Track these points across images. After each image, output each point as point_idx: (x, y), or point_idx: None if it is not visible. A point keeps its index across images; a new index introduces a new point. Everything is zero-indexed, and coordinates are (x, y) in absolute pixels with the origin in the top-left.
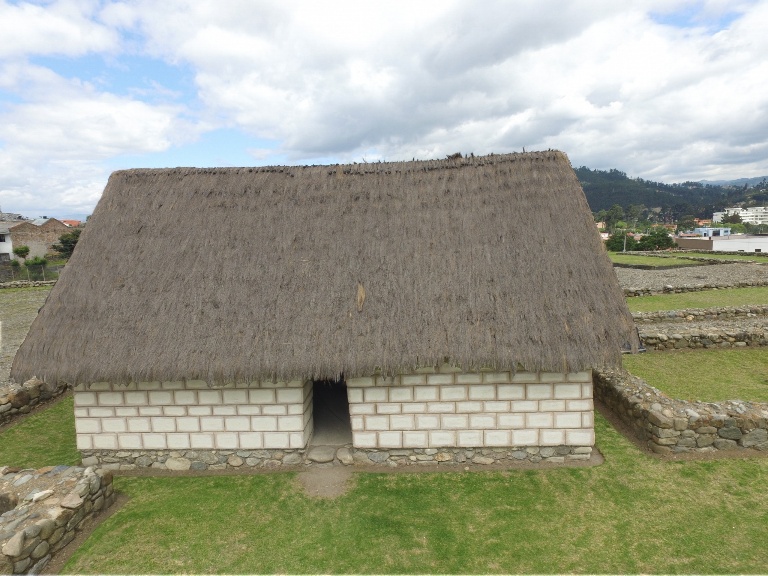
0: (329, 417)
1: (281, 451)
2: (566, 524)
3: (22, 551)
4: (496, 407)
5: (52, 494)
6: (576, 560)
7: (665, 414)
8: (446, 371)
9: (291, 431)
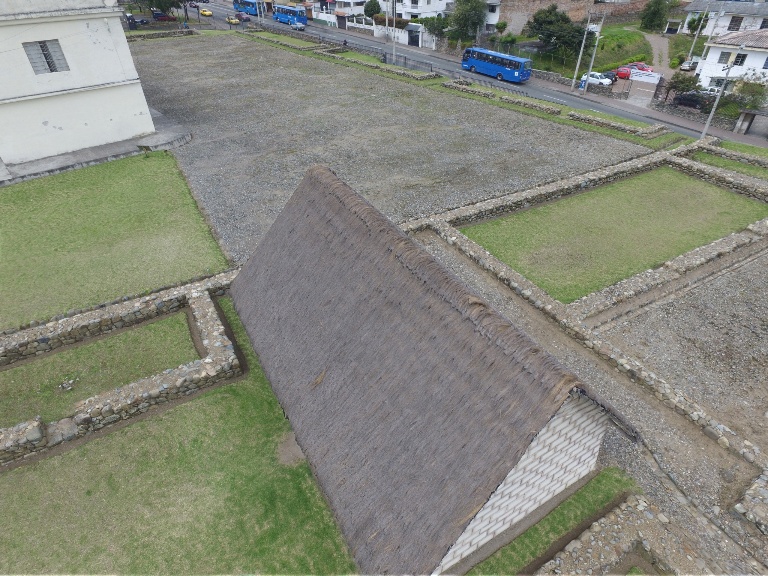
0: None
1: None
2: None
3: None
4: None
5: (211, 363)
6: None
7: None
8: None
9: None
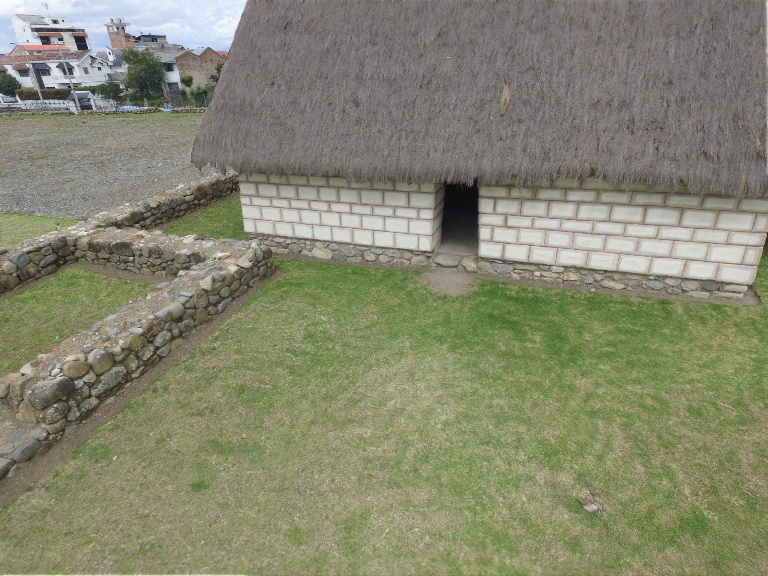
0: (457, 232)
1: (410, 252)
2: (694, 349)
3: (213, 289)
4: (640, 231)
5: (229, 256)
6: (697, 378)
7: None
8: (589, 187)
9: (421, 234)
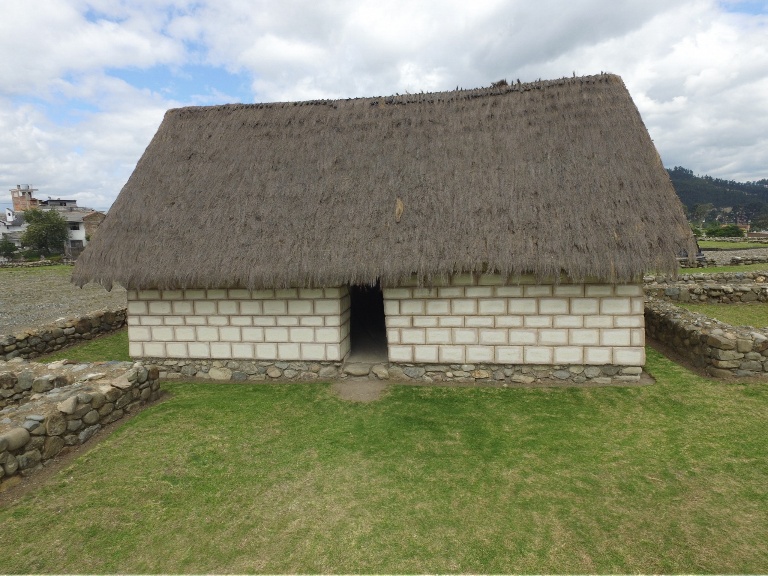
0: (367, 345)
1: (318, 364)
2: (610, 429)
3: (75, 412)
4: (537, 322)
5: (104, 377)
6: (620, 455)
7: (726, 337)
8: (485, 283)
9: (328, 343)
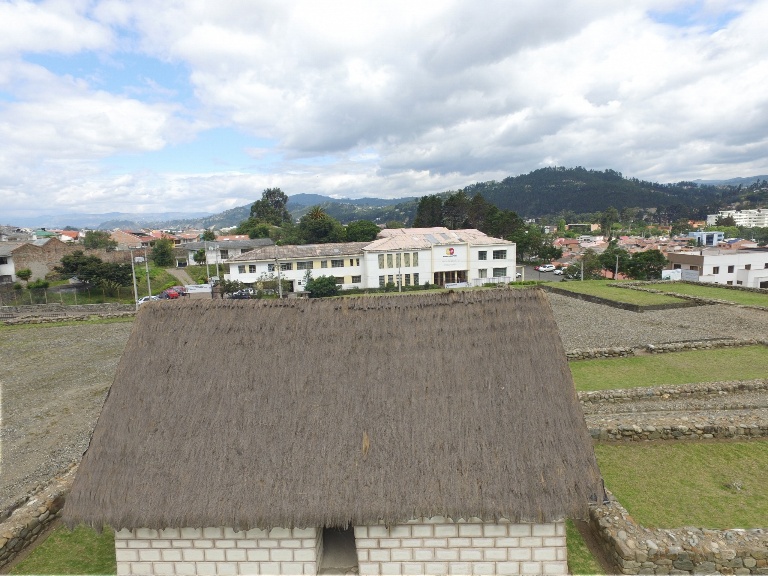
0: None
1: None
2: None
3: None
4: (483, 543)
5: None
6: None
7: (629, 546)
8: (439, 513)
9: (305, 562)
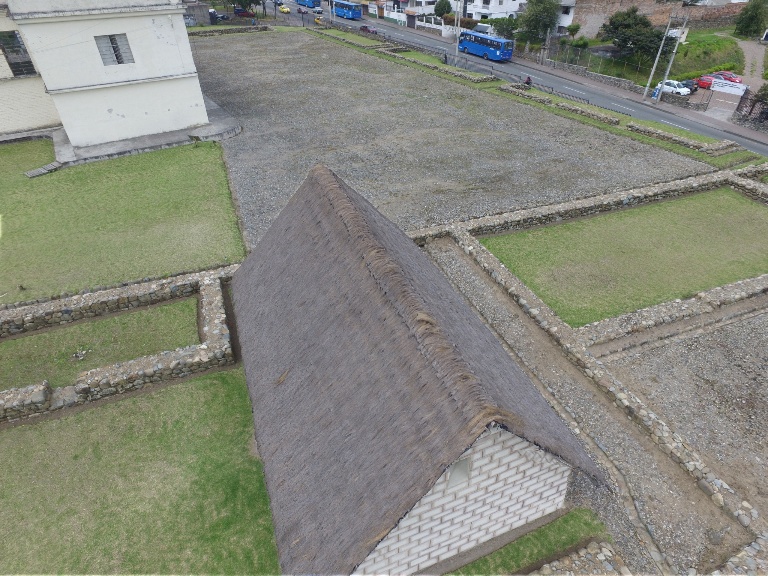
0: None
1: None
2: None
3: (175, 368)
4: None
5: (205, 349)
6: None
7: None
8: None
9: None
